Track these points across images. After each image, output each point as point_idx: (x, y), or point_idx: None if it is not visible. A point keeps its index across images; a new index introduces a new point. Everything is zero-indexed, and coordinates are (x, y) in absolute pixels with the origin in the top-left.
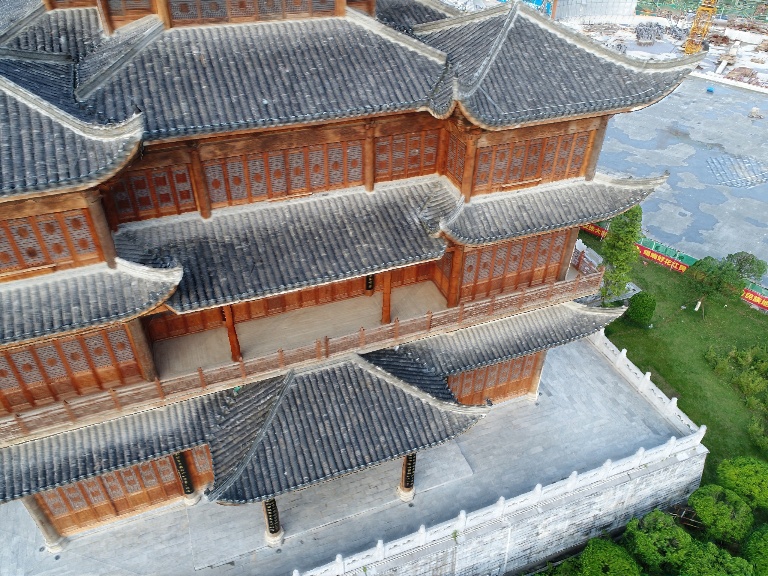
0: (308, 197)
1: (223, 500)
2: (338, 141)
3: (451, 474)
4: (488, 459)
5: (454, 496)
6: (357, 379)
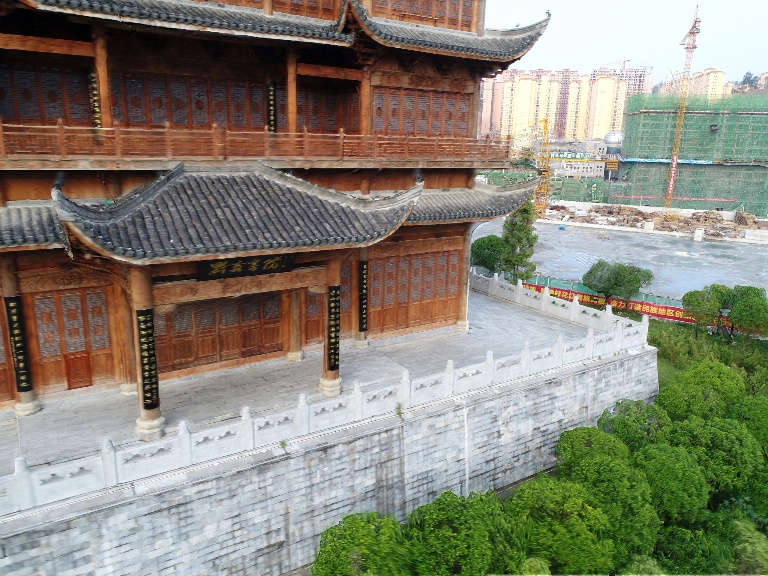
0: (202, 3)
1: (80, 222)
2: None
3: (384, 373)
4: (425, 365)
5: None
6: (262, 186)
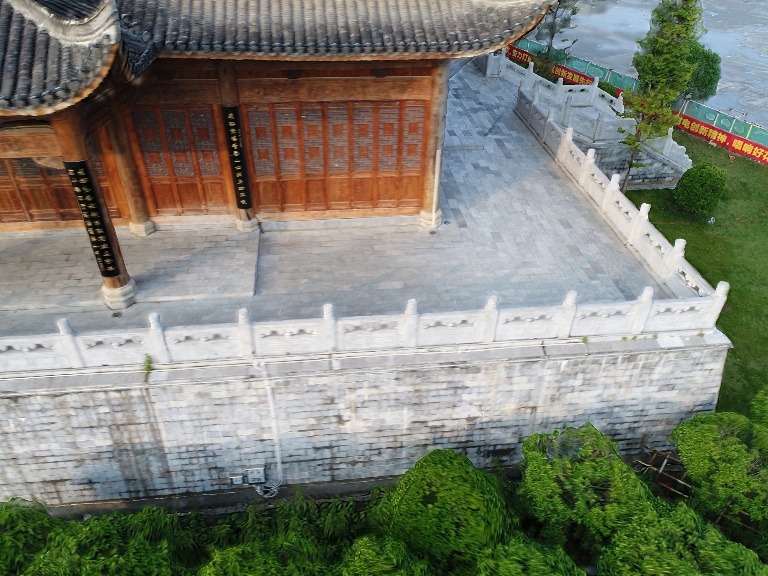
0: None
1: None
2: None
3: (214, 286)
4: (297, 282)
5: (198, 316)
6: None
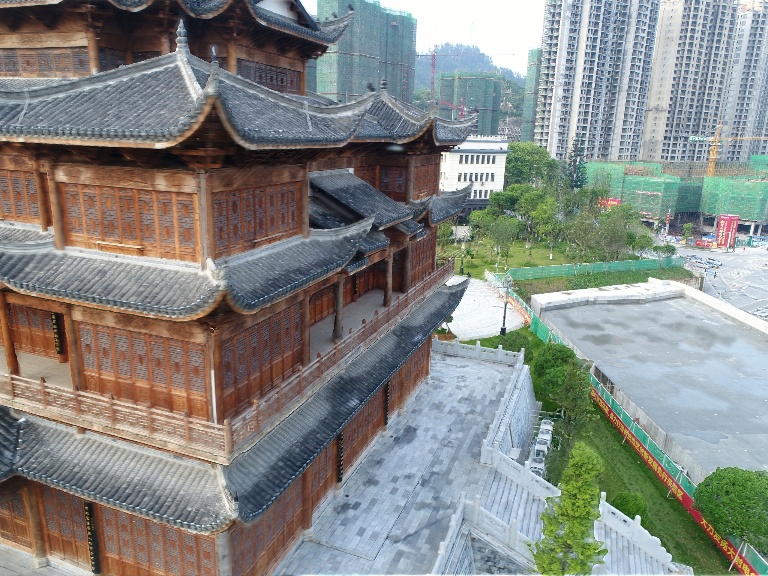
0: (0, 222)
1: None
2: (14, 169)
3: None
4: None
5: None
6: None
